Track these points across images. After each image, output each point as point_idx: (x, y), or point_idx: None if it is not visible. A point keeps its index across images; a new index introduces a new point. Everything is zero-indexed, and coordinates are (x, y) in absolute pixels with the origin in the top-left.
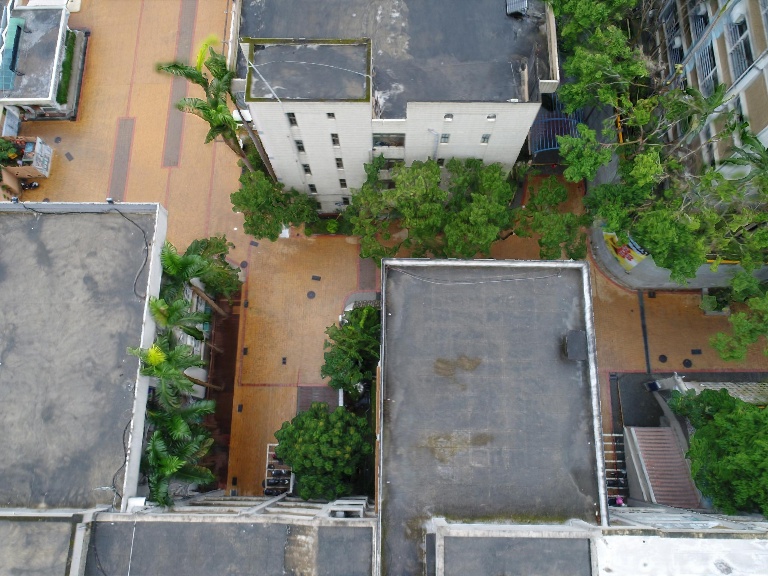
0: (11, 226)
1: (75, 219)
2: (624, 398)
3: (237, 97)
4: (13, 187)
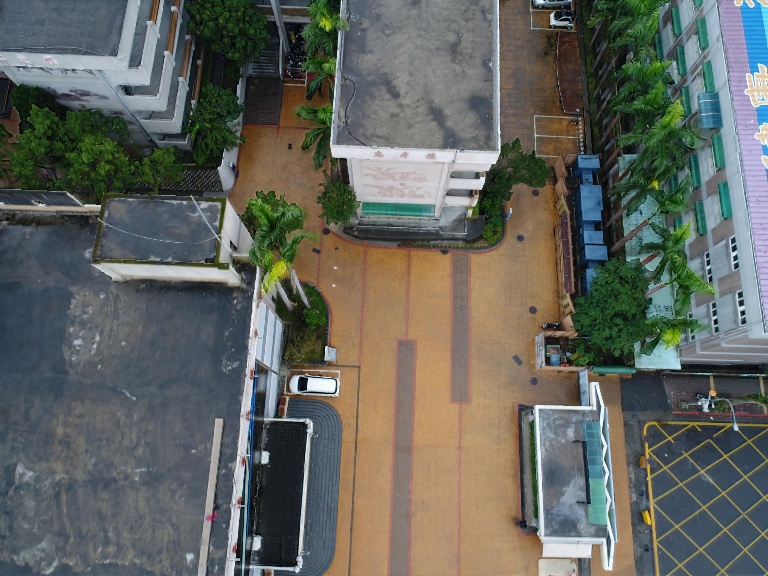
0: (472, 143)
1: (414, 146)
2: (3, 99)
3: (335, 418)
4: (566, 321)
